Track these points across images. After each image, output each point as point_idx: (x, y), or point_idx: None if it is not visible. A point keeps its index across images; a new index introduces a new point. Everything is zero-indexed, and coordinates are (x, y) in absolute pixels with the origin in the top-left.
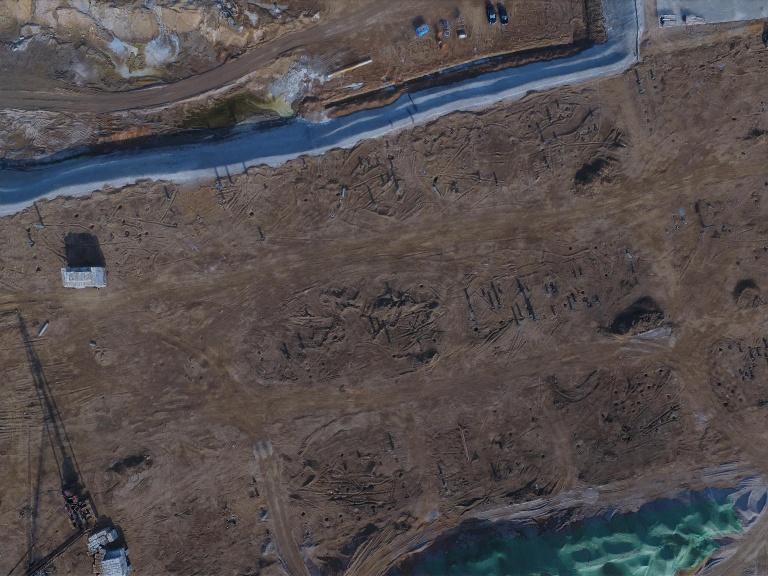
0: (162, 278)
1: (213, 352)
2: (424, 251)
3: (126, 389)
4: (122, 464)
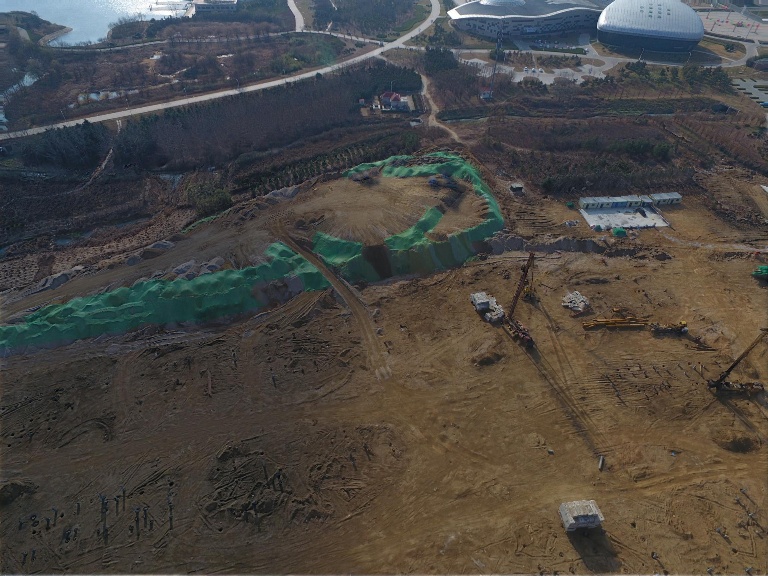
0: (504, 523)
1: (438, 449)
2: (209, 575)
3: (509, 414)
4: (495, 360)
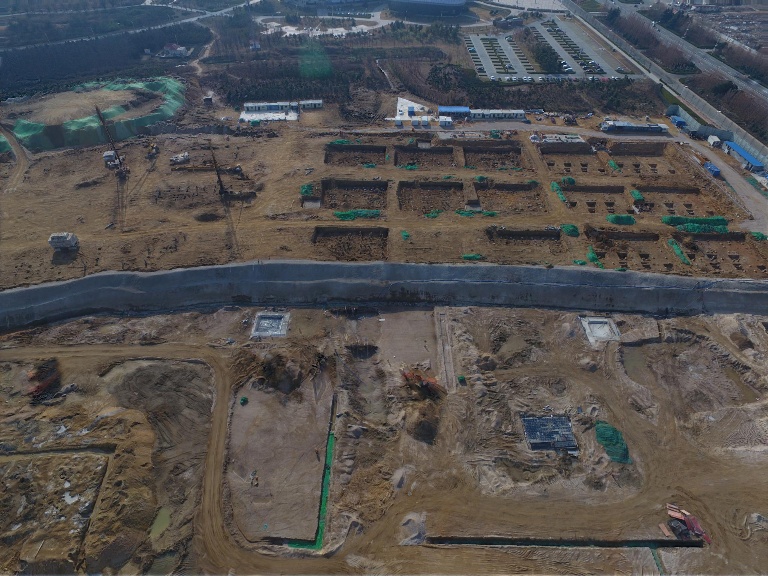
0: None
1: None
2: None
3: None
4: (92, 184)
